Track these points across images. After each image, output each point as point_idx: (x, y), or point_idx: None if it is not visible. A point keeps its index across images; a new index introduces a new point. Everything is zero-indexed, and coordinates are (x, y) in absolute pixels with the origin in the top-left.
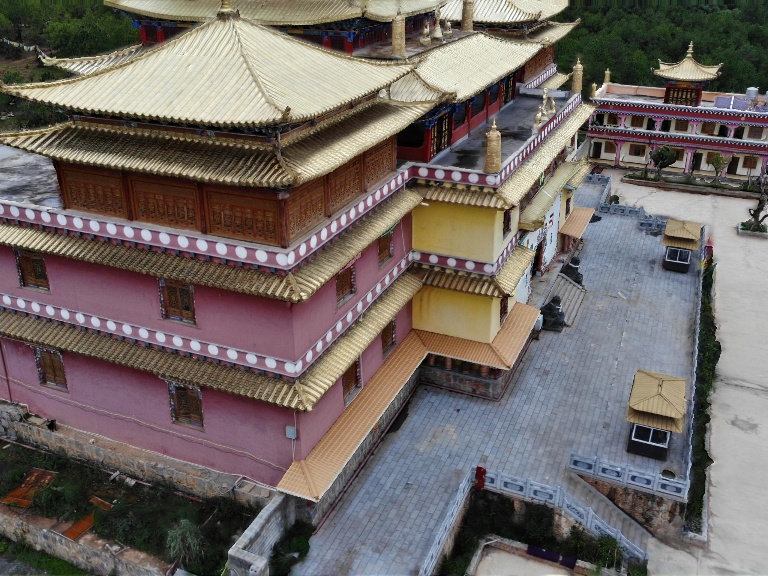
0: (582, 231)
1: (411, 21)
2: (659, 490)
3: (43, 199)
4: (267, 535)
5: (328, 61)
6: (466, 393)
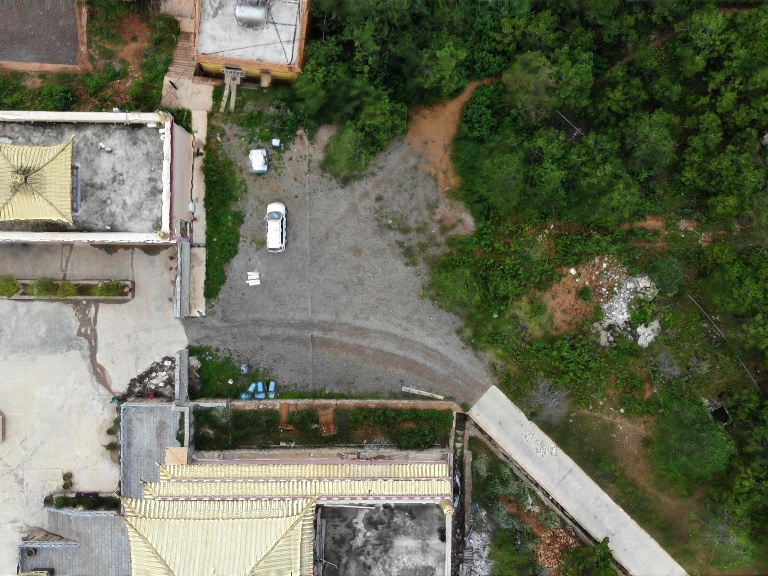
0: None
1: None
2: None
3: (355, 535)
4: None
5: None
6: None
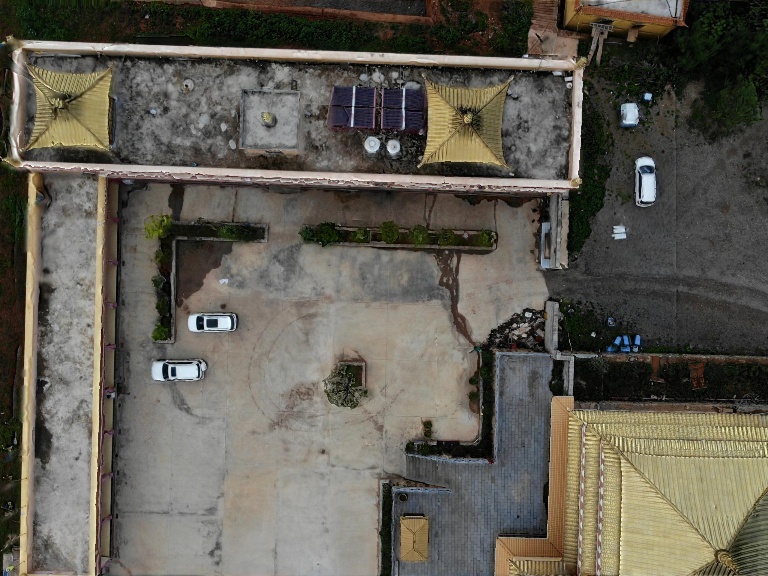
0: None
1: None
2: (406, 488)
3: None
4: None
5: None
6: (518, 535)
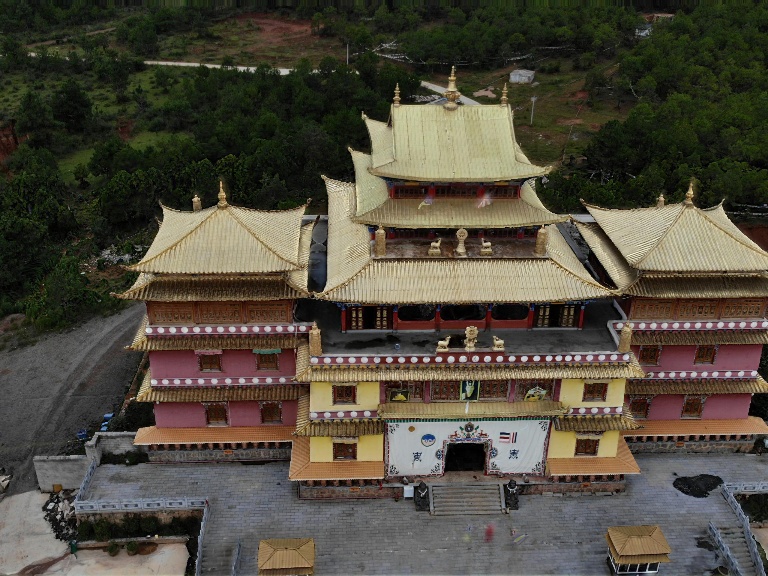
0: (570, 473)
1: (489, 229)
2: None
3: None
4: (122, 443)
5: (250, 246)
6: None
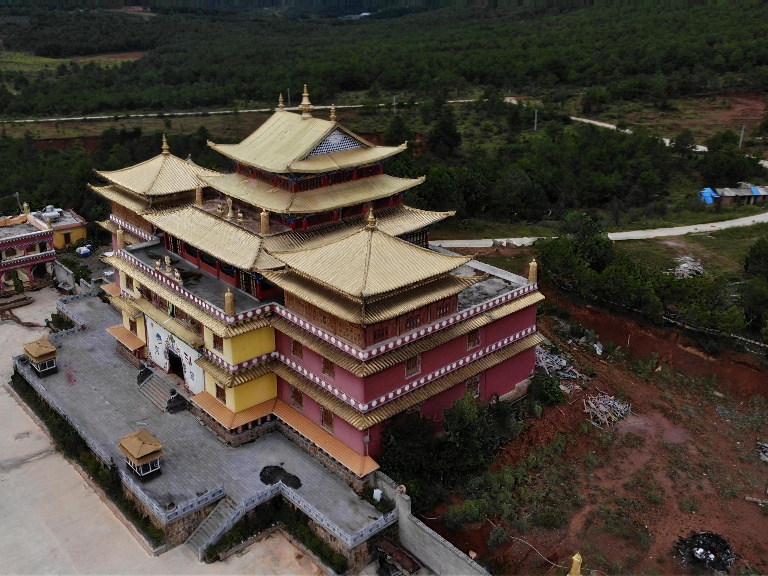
0: (199, 404)
1: (269, 211)
2: None
3: None
4: None
5: None
6: None
